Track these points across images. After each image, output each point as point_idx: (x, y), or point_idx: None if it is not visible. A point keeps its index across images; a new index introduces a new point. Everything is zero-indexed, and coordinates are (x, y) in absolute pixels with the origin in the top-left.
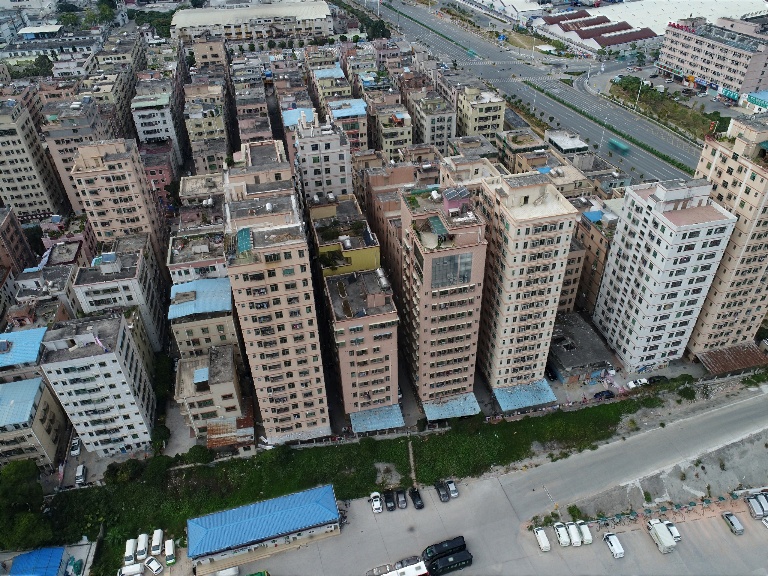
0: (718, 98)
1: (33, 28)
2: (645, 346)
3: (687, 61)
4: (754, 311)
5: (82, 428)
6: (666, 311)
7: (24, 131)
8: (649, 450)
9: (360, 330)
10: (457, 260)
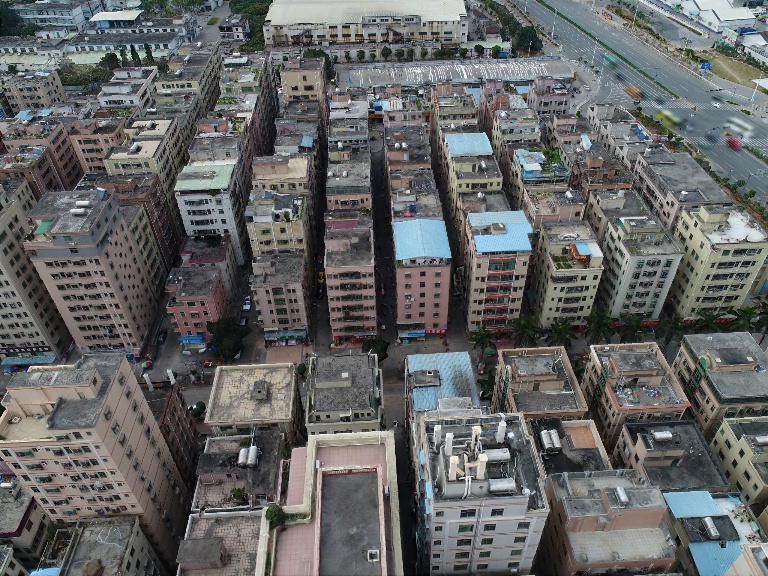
0: None
1: (109, 14)
2: None
3: None
4: None
5: None
6: None
7: (3, 242)
8: None
9: None
10: None
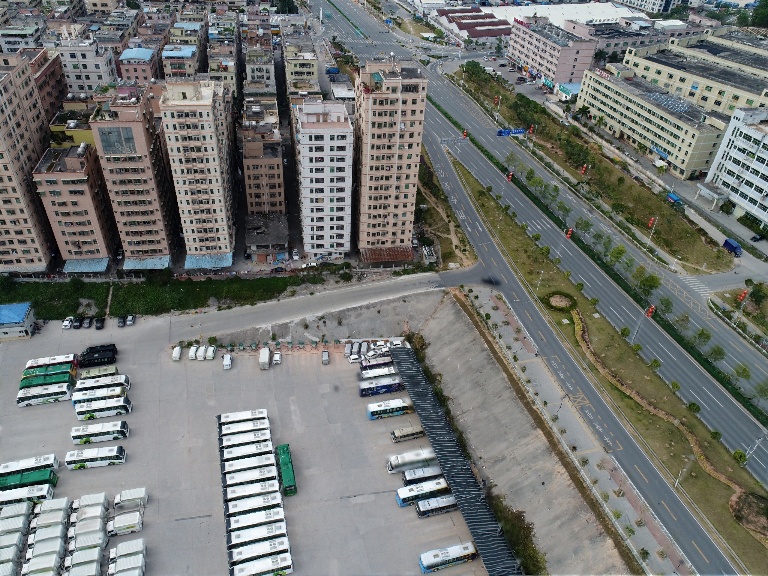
0: (540, 86)
1: None
2: (312, 234)
3: (524, 53)
4: (401, 216)
5: None
6: (319, 204)
7: None
8: (291, 308)
9: (56, 183)
10: (120, 132)
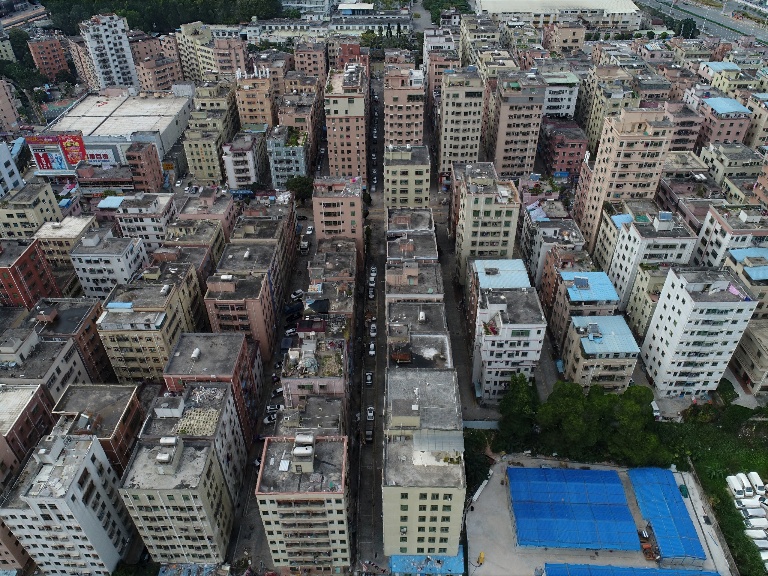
0: None
1: (350, 5)
2: None
3: None
4: None
5: (673, 367)
6: None
7: None
8: None
9: None
10: None
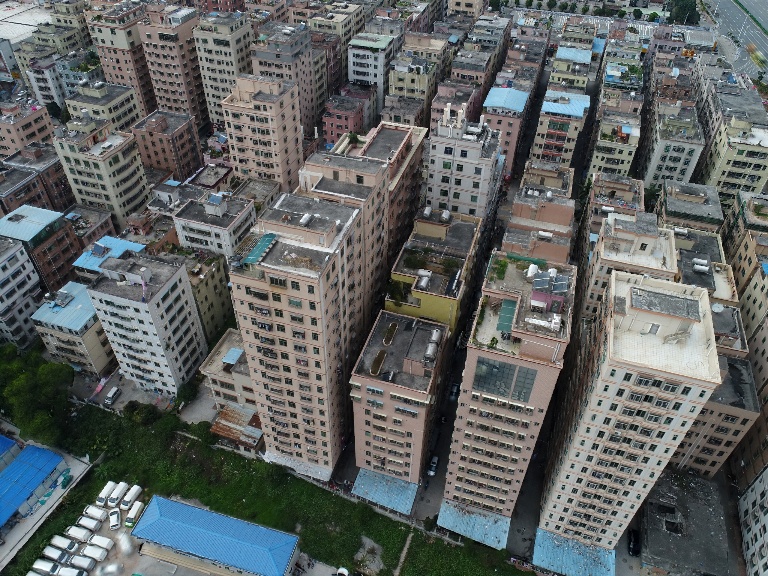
0: None
1: None
2: None
3: None
4: None
5: (121, 357)
6: None
7: (238, 45)
8: None
9: (380, 393)
10: (513, 371)
